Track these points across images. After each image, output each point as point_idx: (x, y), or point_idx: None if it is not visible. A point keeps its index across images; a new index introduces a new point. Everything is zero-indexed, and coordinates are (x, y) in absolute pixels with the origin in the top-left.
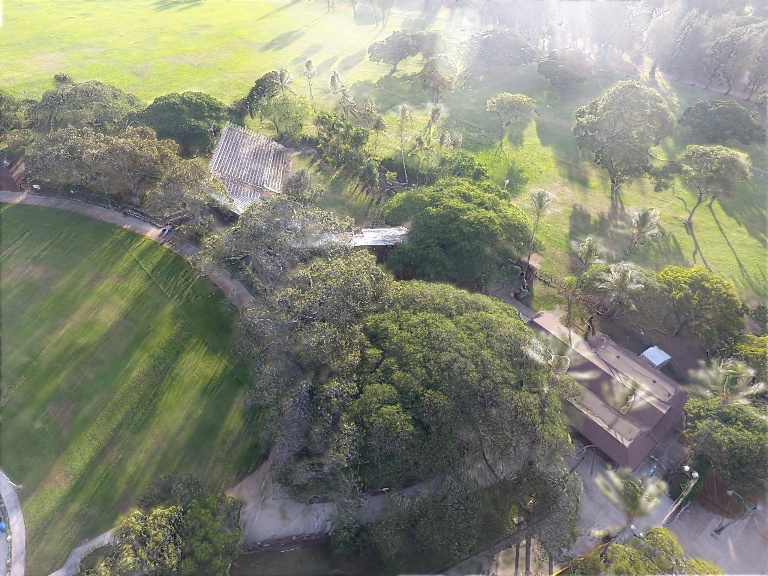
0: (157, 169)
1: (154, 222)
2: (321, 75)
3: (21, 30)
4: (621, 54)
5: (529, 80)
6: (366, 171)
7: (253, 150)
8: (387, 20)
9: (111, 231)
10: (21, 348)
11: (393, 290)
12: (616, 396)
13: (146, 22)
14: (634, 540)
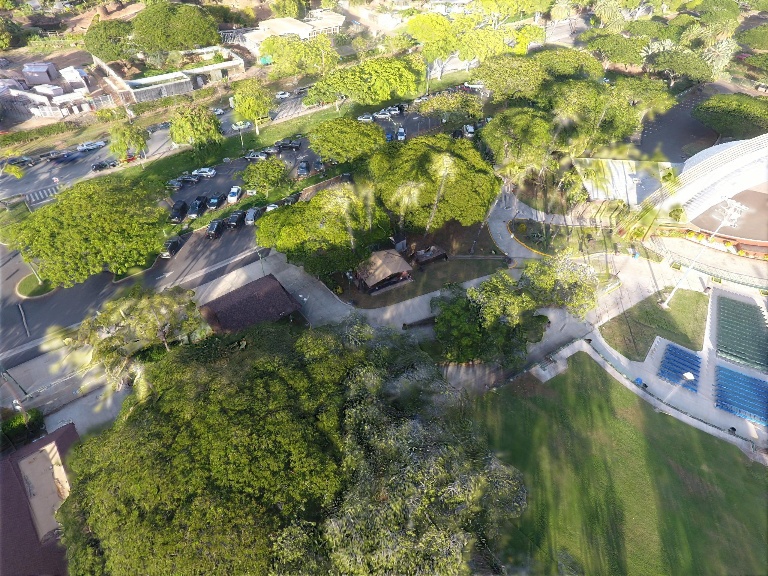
0: None
1: None
2: None
3: None
4: None
5: None
6: None
7: None
8: None
9: None
10: None
11: (287, 562)
12: (7, 502)
13: None
14: (112, 392)
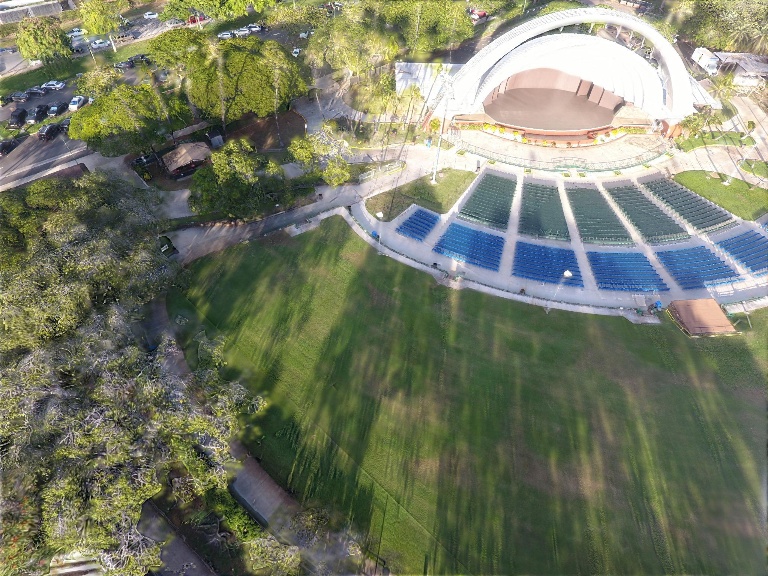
0: None
1: None
2: None
3: None
4: None
5: None
6: None
7: None
8: None
9: None
10: (474, 357)
11: None
12: None
13: None
14: None
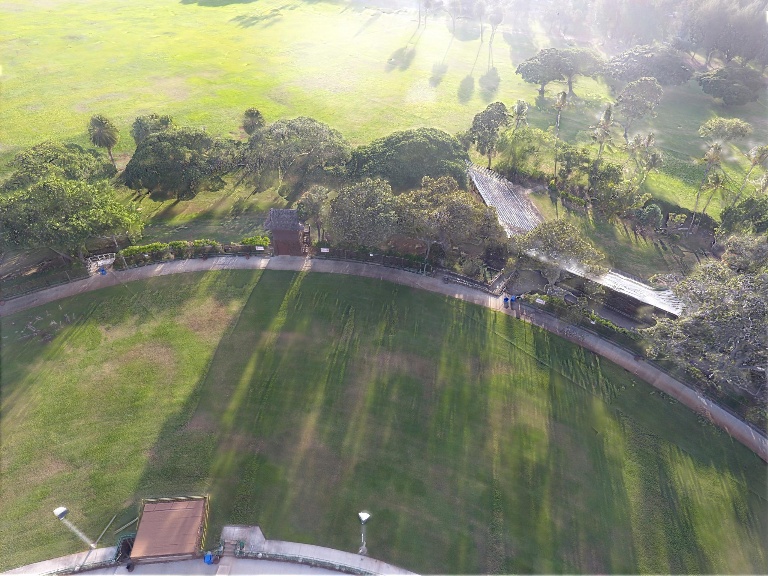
0: (498, 229)
1: (487, 289)
2: (473, 98)
3: (114, 52)
4: (762, 69)
5: (685, 98)
6: (651, 214)
7: (499, 191)
8: (493, 35)
9: (447, 303)
10: (463, 470)
11: None
12: None
13: (241, 41)
14: None
